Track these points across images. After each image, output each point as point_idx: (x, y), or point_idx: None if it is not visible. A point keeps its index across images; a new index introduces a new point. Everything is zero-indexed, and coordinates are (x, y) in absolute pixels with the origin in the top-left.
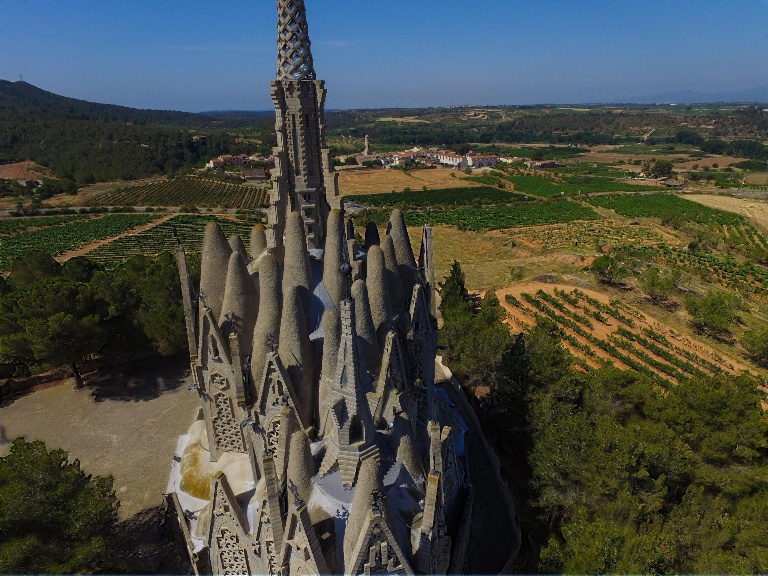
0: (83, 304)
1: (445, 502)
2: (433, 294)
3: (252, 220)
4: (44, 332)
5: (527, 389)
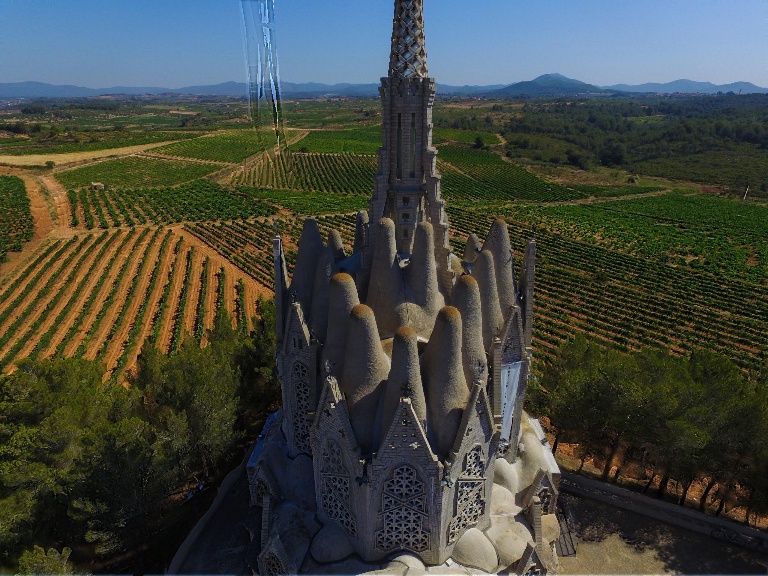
0: None
1: None
2: None
3: None
4: None
5: None
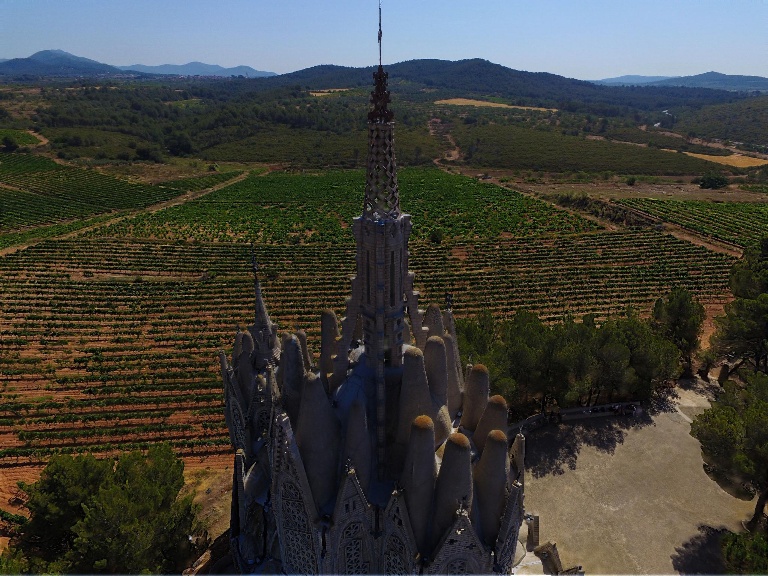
0: (765, 451)
1: None
2: None
3: None
4: (703, 420)
5: None
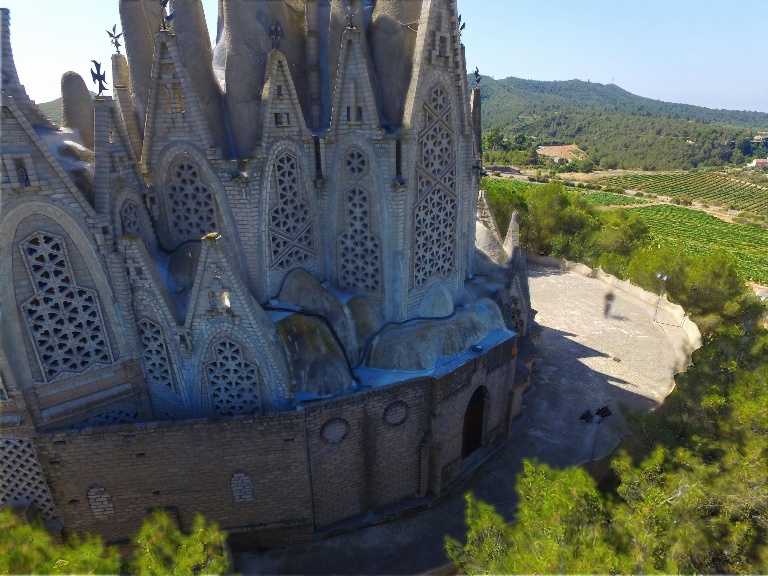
0: None
1: (236, 384)
2: (415, 75)
3: (752, 226)
4: None
5: (690, 438)
